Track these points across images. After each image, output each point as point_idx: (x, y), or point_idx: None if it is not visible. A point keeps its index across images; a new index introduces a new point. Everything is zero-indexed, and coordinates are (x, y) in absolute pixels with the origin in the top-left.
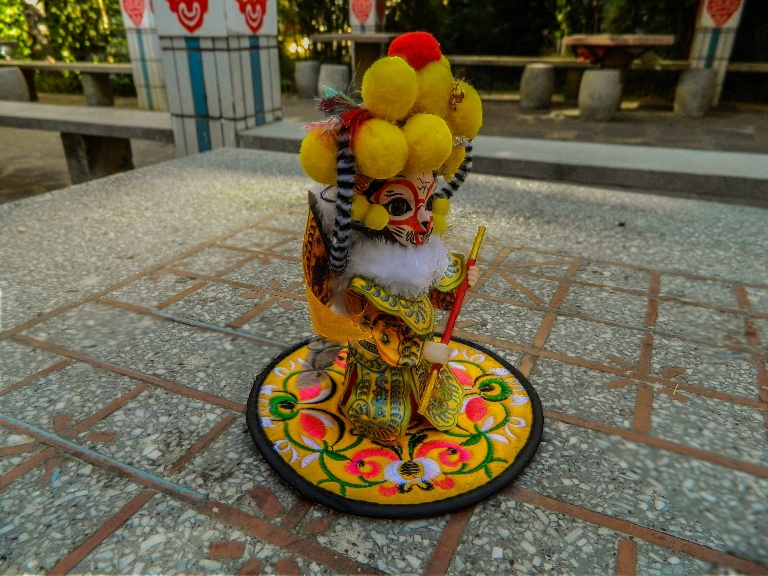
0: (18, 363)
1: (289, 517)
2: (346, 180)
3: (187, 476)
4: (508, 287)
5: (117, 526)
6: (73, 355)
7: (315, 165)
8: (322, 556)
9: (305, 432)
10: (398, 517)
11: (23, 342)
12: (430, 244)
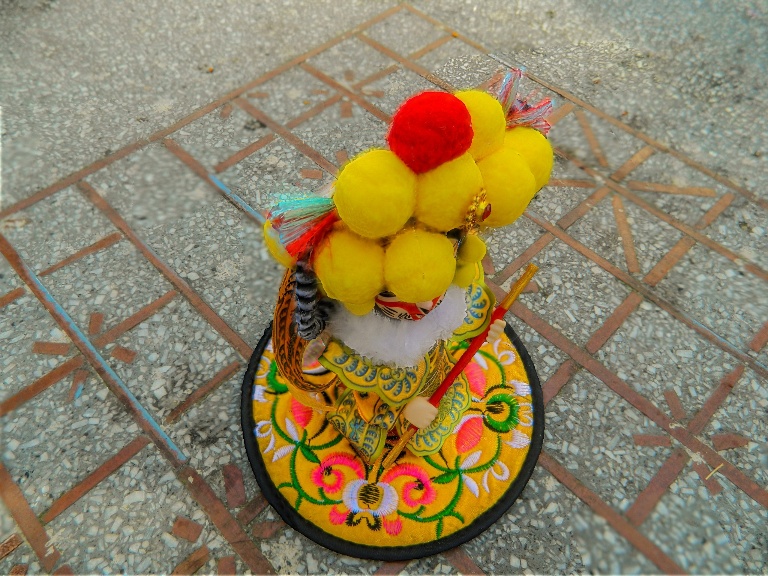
0: (76, 226)
1: (246, 511)
2: (303, 295)
3: (179, 430)
4: (610, 229)
5: (112, 470)
6: (123, 228)
7: (275, 256)
8: (258, 566)
9: (291, 414)
10: (334, 551)
11: (86, 194)
12: (440, 307)
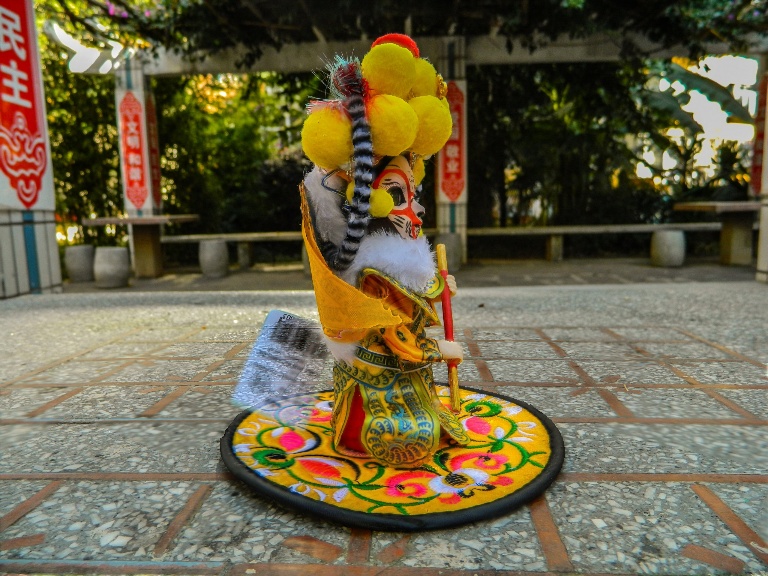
0: None
1: (353, 553)
2: (367, 148)
3: (185, 550)
4: None
5: None
6: None
7: (327, 139)
8: (424, 575)
9: (316, 474)
10: (481, 518)
11: None
12: None
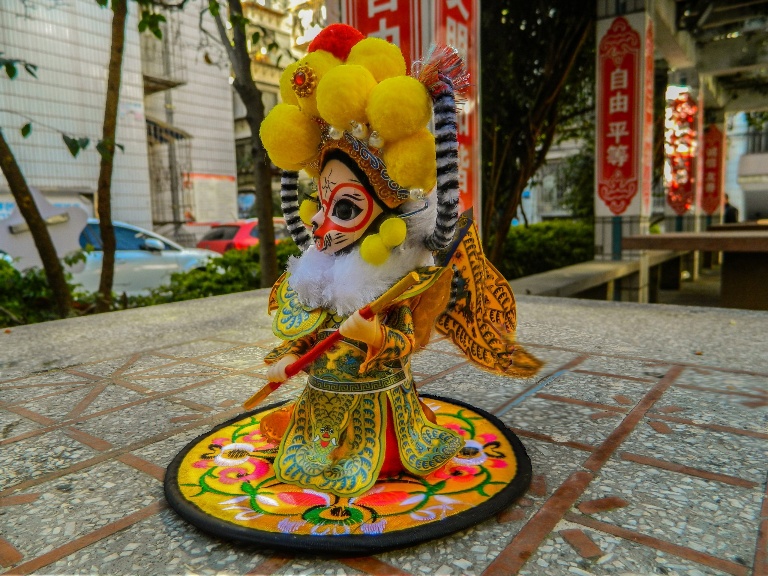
0: None
1: None
2: None
3: None
4: None
5: None
6: None
7: None
8: None
9: None
10: None
11: None
12: (340, 259)
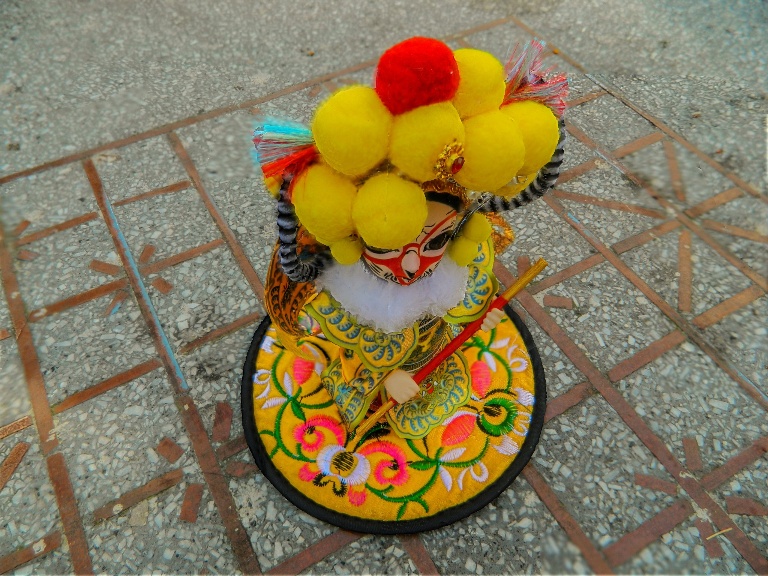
0: (156, 169)
1: (226, 448)
2: (282, 226)
3: (189, 361)
4: (669, 263)
5: (122, 382)
6: (195, 177)
7: None
8: (222, 500)
9: (291, 370)
10: None
11: (172, 144)
12: (433, 279)
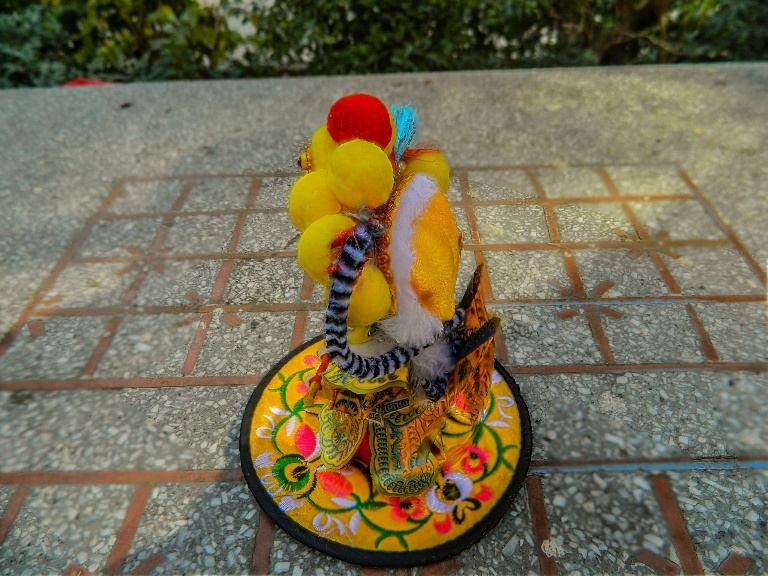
0: (745, 341)
1: None
2: None
3: None
4: None
5: None
6: (723, 365)
7: None
8: None
9: None
10: None
11: None
12: None
